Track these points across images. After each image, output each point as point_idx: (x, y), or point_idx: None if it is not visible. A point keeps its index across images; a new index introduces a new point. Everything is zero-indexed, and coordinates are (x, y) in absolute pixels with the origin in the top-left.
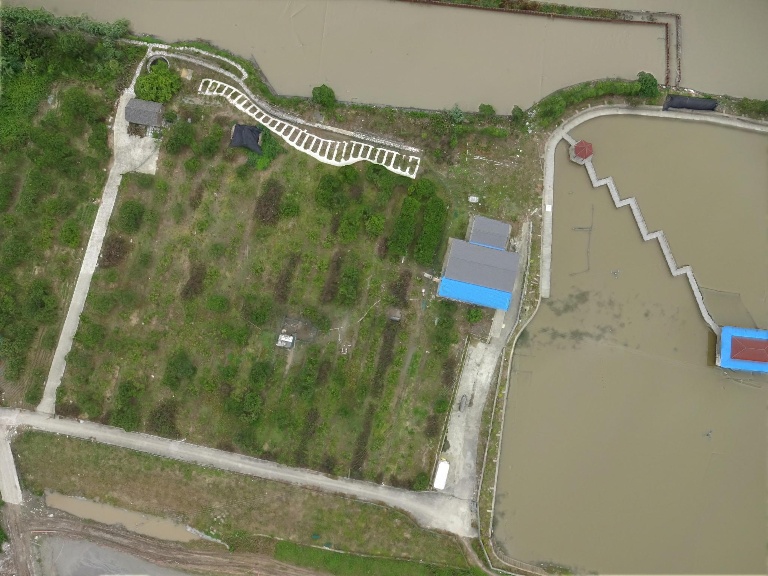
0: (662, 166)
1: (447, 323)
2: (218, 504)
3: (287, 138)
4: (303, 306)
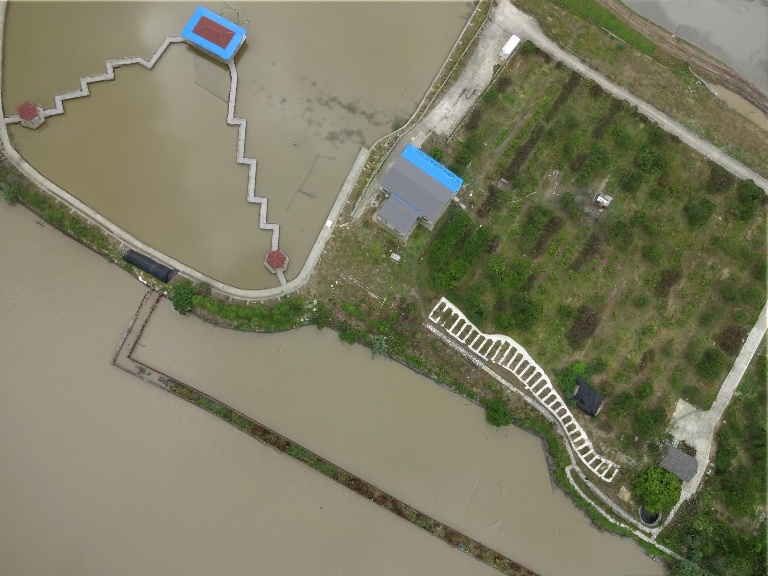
0: (206, 220)
1: (464, 156)
2: (690, 101)
3: (548, 385)
4: (579, 224)
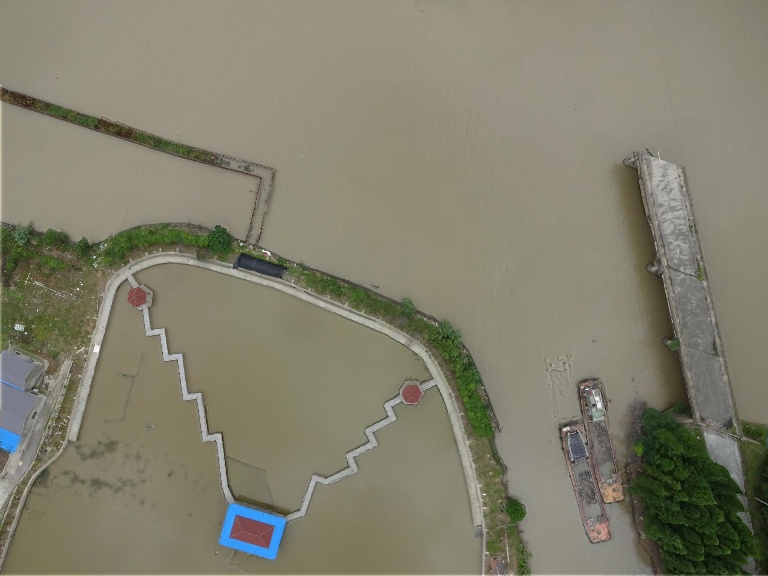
0: (222, 325)
1: None
2: None
3: None
4: None
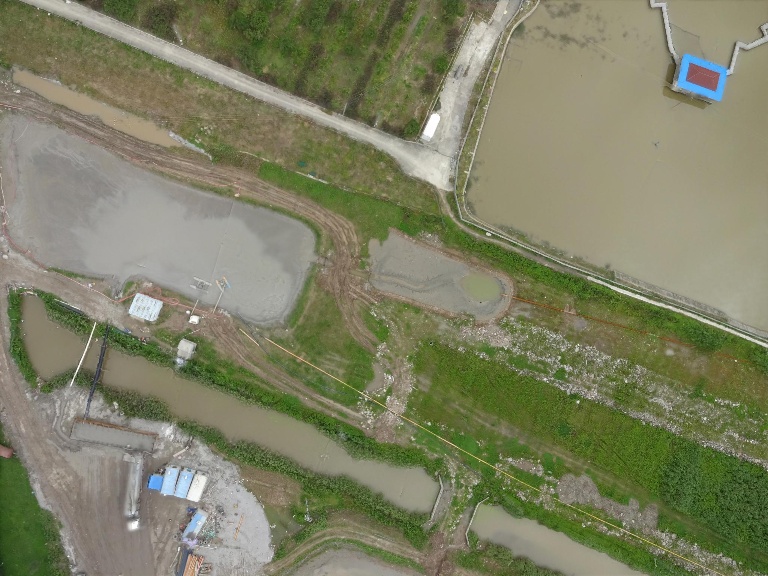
0: None
1: None
2: (207, 116)
3: None
4: None
